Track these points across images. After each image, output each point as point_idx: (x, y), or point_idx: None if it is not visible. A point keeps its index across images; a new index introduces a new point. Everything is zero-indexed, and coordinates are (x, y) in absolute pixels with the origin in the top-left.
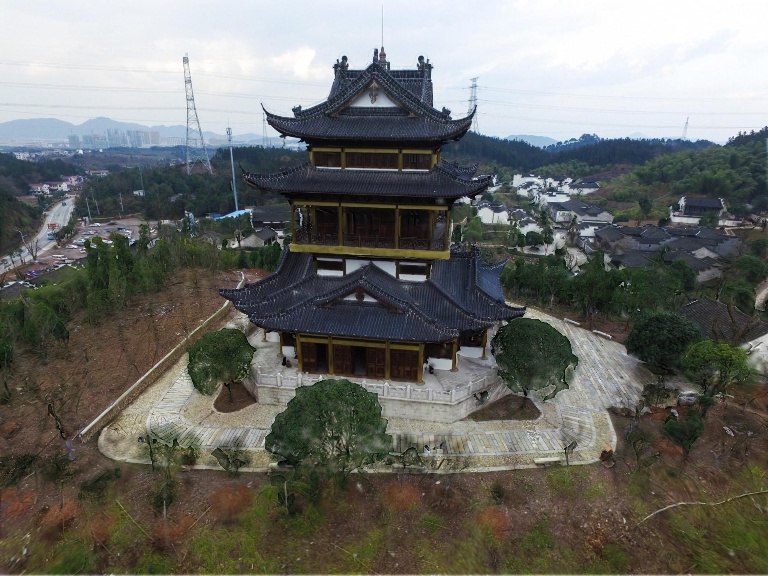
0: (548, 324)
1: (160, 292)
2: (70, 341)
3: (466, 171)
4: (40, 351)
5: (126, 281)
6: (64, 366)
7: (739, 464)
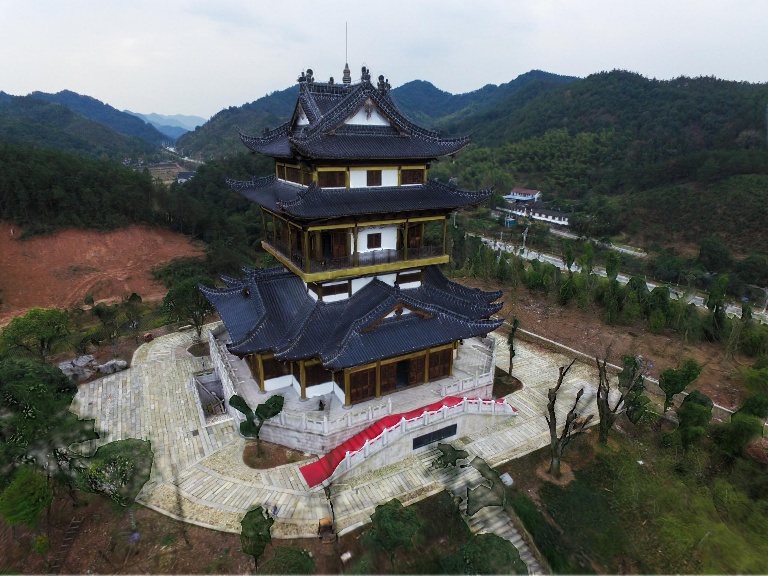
0: (182, 287)
1: (600, 321)
2: (510, 287)
3: (290, 206)
4: (509, 284)
5: (641, 311)
6: (474, 283)
7: (54, 358)
